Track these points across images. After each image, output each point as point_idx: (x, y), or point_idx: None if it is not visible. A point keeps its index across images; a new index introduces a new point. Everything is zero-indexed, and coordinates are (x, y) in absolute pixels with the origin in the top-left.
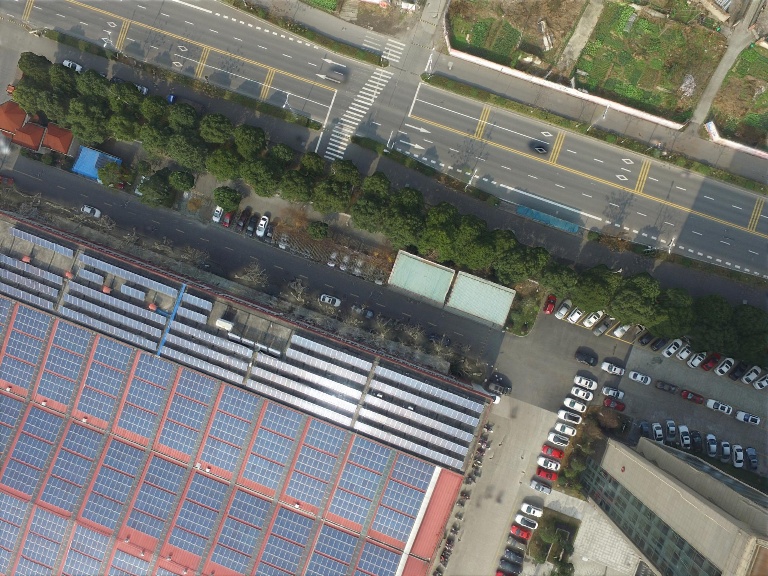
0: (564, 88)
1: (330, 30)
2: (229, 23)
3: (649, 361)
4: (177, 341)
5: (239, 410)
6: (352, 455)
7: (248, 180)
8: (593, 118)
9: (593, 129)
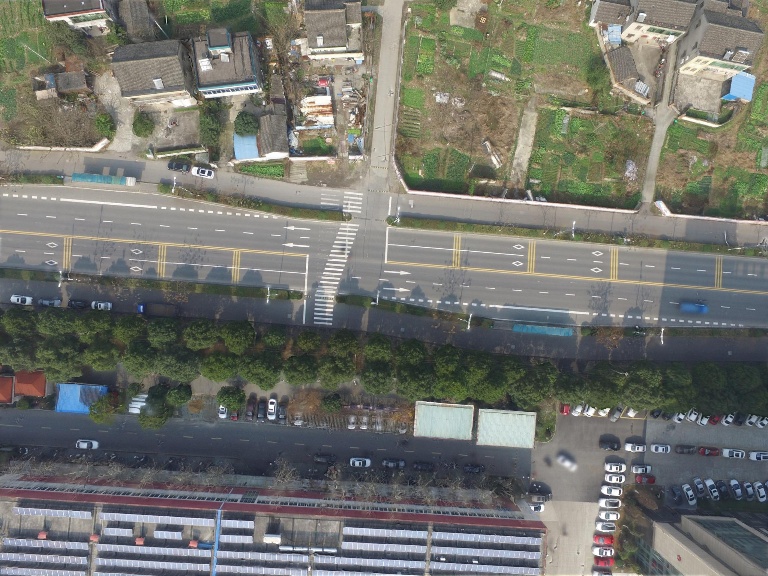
0: (523, 201)
1: (284, 197)
2: (178, 214)
3: (664, 430)
4: (228, 569)
5: None
6: None
7: (251, 382)
8: (556, 221)
9: (559, 232)
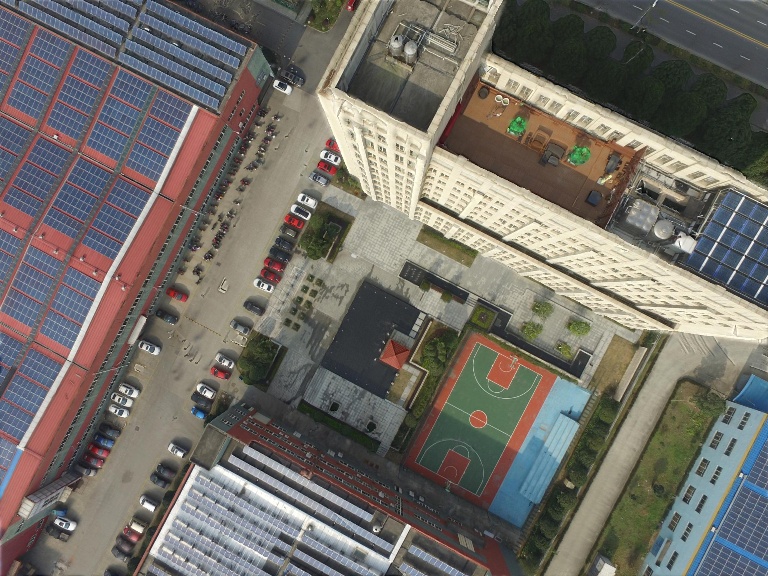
0: None
1: None
2: None
3: None
4: None
5: (9, 34)
6: (114, 88)
7: None
8: None
9: None
